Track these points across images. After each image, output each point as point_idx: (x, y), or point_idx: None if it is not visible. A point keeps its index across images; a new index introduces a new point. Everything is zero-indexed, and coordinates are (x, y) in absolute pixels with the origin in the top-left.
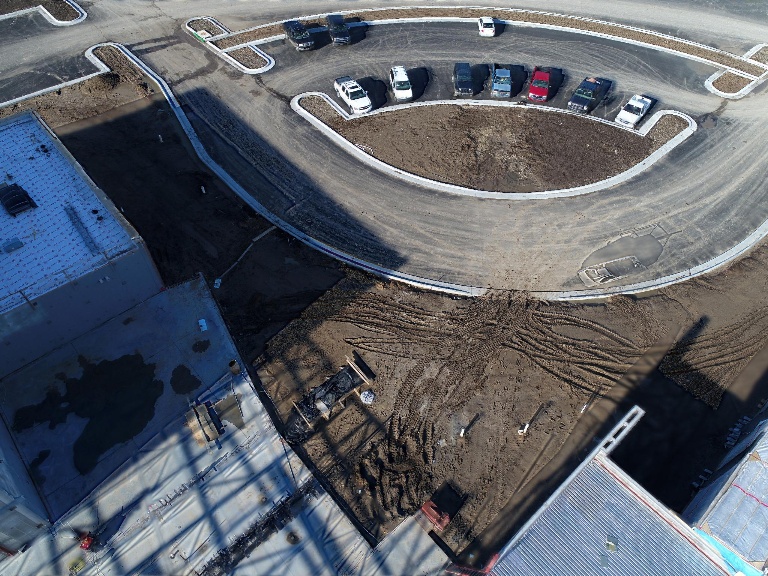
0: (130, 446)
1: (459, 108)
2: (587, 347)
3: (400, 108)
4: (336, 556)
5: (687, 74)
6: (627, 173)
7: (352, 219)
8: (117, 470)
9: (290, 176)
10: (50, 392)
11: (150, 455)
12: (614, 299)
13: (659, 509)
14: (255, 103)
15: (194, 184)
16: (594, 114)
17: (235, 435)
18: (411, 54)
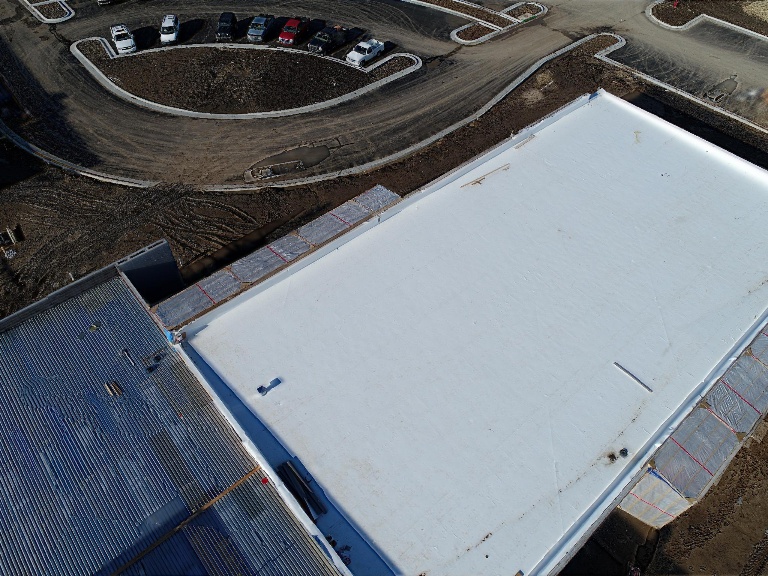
0: None
1: (215, 50)
2: (215, 222)
3: (163, 50)
4: None
5: (440, 25)
6: (335, 100)
7: (74, 132)
8: None
9: (39, 100)
10: None
11: None
12: (261, 190)
13: None
14: (40, 46)
15: None
16: (333, 55)
17: None
18: (199, 8)
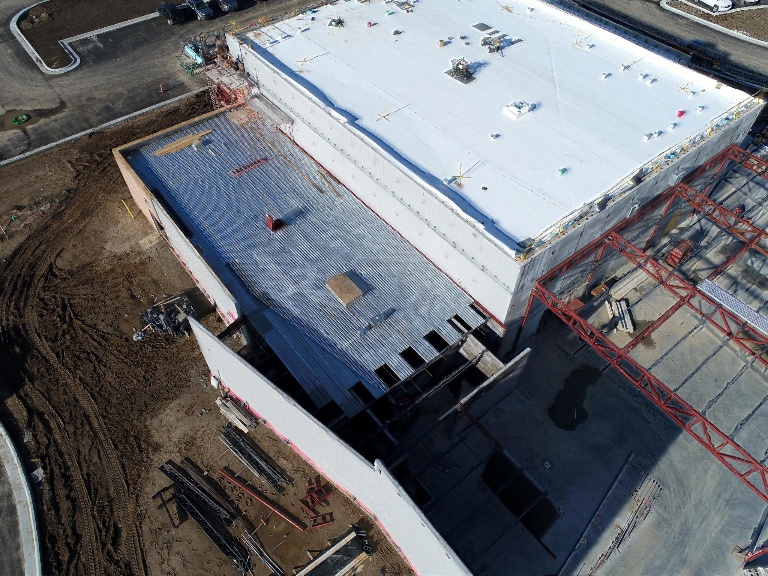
0: None
1: None
2: None
3: (750, 9)
4: None
5: None
6: None
7: (764, 72)
8: (720, 185)
9: (698, 47)
10: None
11: (735, 179)
12: None
13: None
14: (633, 5)
15: None
16: None
17: None
18: None
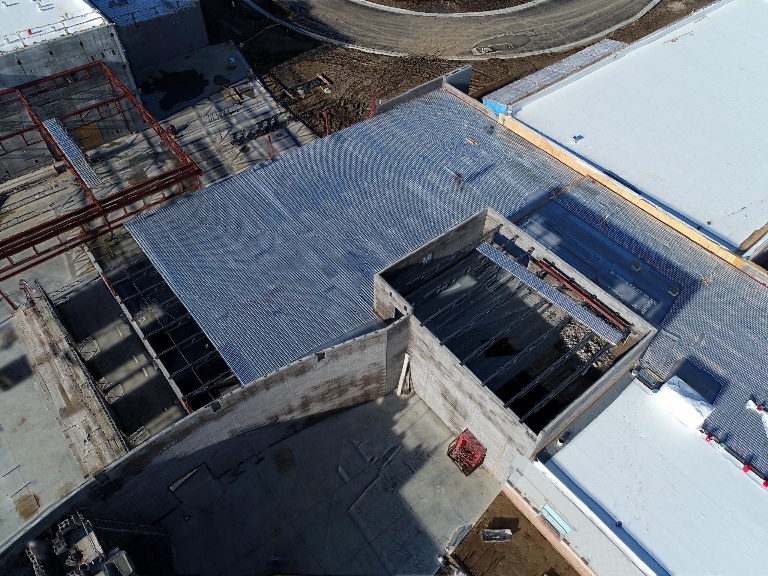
0: (191, 102)
1: None
2: None
3: None
4: (302, 141)
5: None
6: (520, 6)
7: (330, 22)
8: (184, 110)
9: (291, 2)
10: (144, 82)
11: (202, 105)
12: (490, 60)
13: (469, 100)
14: None
15: (227, 3)
16: None
17: (250, 100)
18: None
